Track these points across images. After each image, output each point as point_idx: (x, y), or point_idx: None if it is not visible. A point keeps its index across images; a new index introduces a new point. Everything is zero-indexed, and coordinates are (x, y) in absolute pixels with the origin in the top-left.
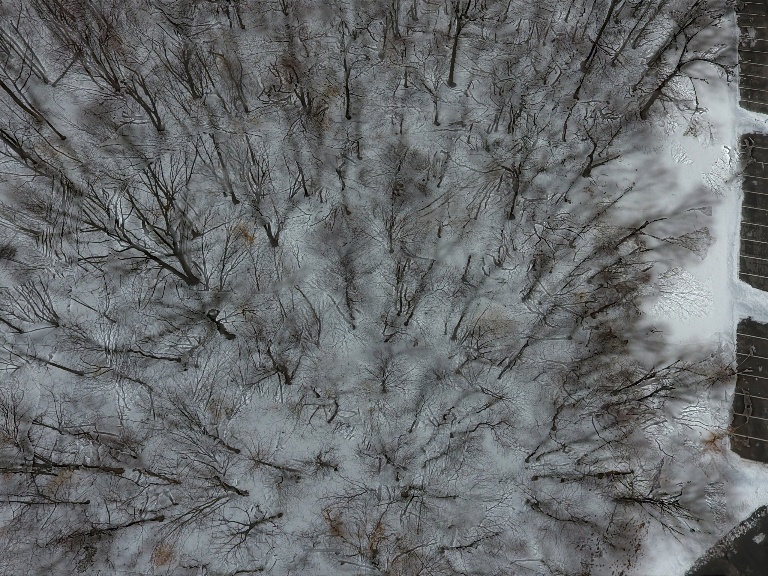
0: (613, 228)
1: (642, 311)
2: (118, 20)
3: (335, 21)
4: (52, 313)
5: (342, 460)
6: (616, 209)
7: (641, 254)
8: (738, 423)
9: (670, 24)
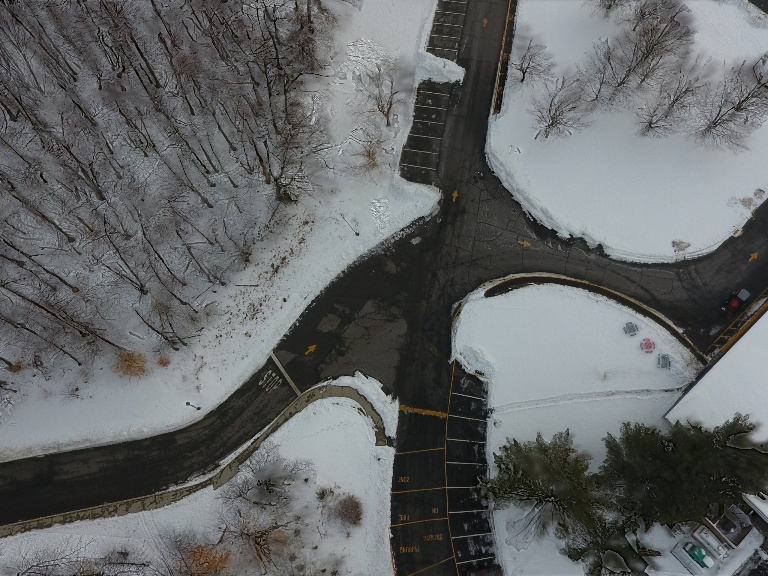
0: (305, 3)
1: (327, 67)
2: None
3: None
4: None
5: (48, 170)
6: None
7: (332, 26)
8: (409, 156)
9: None
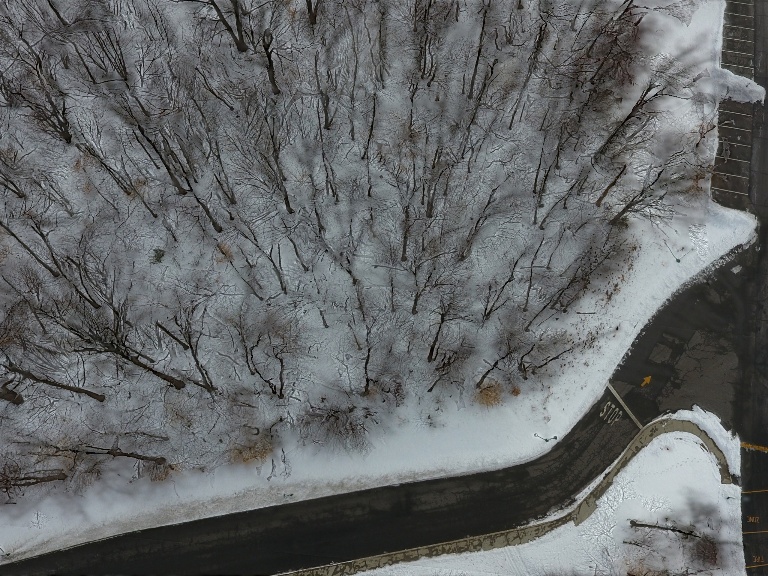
0: (610, 13)
1: (635, 83)
2: None
3: None
4: (122, 65)
5: (375, 184)
6: (612, 3)
7: (634, 38)
8: (719, 180)
9: None
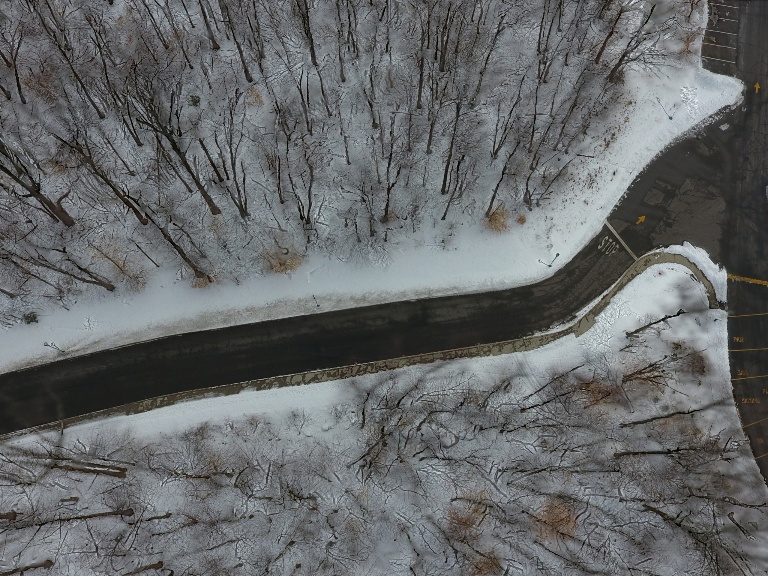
0: None
1: None
2: None
3: None
4: None
5: (392, 41)
6: None
7: None
8: (709, 50)
9: None
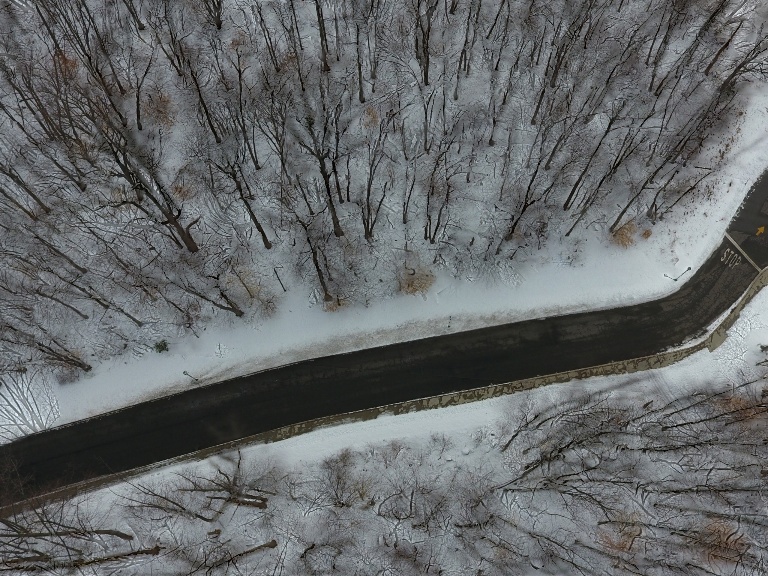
0: None
1: None
2: None
3: None
4: None
5: (502, 58)
6: None
7: None
8: None
9: None
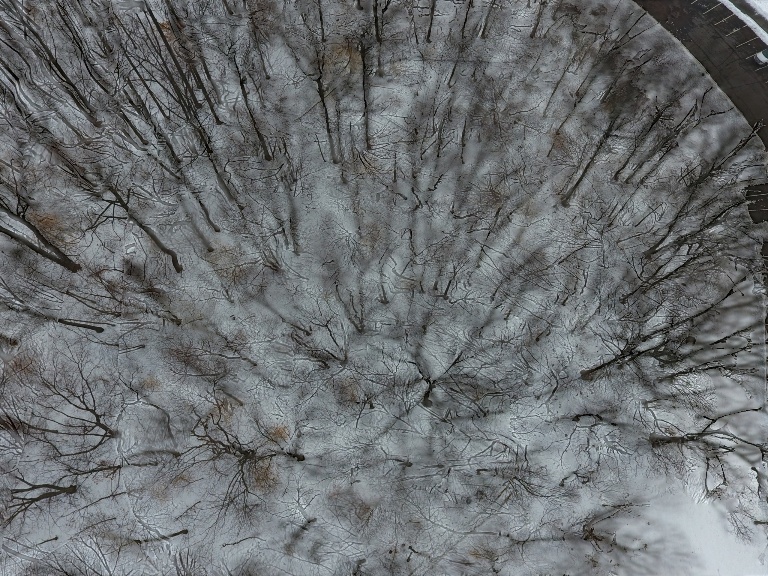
0: None
1: None
2: (22, 340)
3: (286, 331)
4: None
5: None
6: None
7: None
8: None
9: (687, 312)
